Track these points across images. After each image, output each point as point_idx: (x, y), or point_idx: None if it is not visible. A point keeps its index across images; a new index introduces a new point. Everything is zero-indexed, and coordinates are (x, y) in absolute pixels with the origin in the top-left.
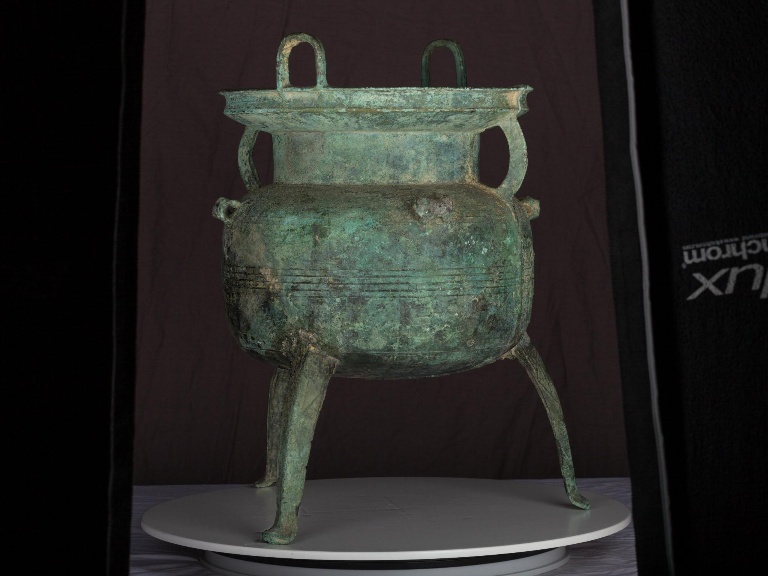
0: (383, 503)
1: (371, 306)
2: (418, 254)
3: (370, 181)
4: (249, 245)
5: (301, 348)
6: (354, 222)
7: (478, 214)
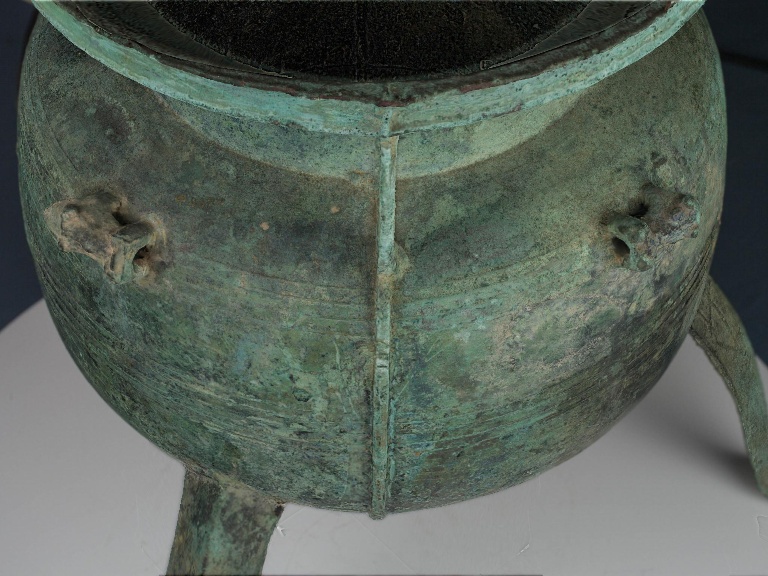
0: (275, 543)
1: None
2: None
3: None
4: None
5: None
6: None
7: None
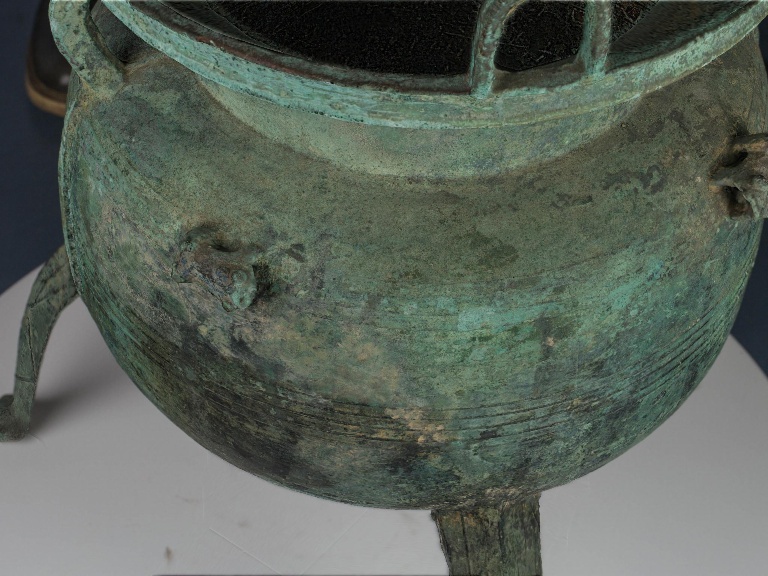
0: None
1: (645, 406)
2: (724, 273)
3: (581, 139)
4: (343, 364)
5: (480, 508)
6: (626, 284)
7: (763, 104)
